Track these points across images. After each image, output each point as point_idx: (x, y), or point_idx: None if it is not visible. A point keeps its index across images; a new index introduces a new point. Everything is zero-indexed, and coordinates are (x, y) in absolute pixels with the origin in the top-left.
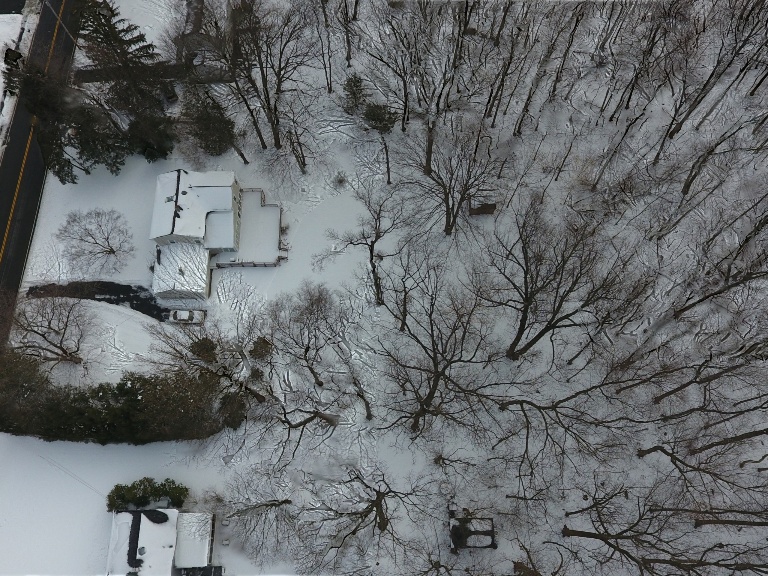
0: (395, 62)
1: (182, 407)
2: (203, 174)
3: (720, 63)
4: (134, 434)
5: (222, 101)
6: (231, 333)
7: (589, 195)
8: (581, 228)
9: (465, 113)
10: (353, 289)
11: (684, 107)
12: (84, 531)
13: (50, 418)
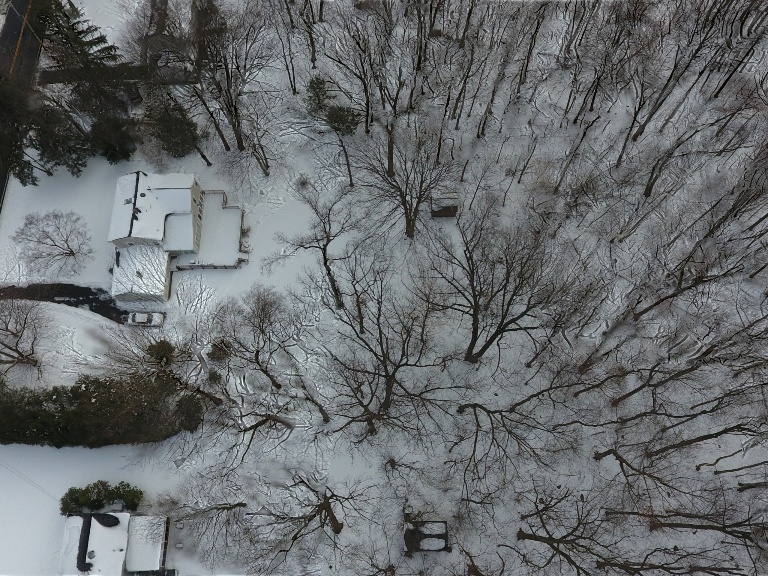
0: (354, 64)
1: (136, 410)
2: (163, 176)
3: (677, 66)
4: (87, 437)
5: (185, 102)
6: (189, 336)
7: (551, 197)
8: (543, 230)
9: (429, 115)
10: (298, 293)
11: (647, 109)
12: (38, 534)
13: (3, 421)
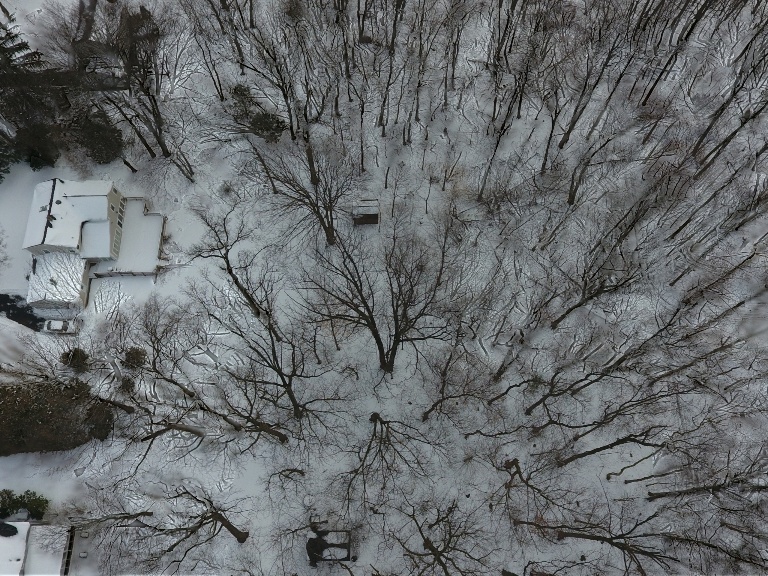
0: (270, 72)
1: (40, 419)
2: (80, 183)
3: (590, 75)
4: None
5: (111, 109)
6: None
7: (475, 205)
8: (465, 238)
9: (356, 122)
10: (183, 304)
11: None
12: None
13: None
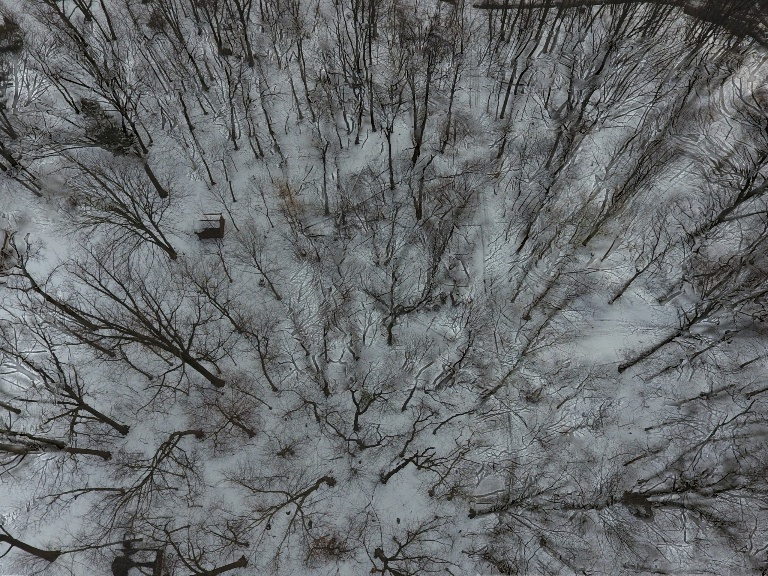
0: (100, 87)
1: None
2: None
3: (415, 91)
4: None
5: None
6: None
7: (322, 220)
8: (309, 253)
9: (209, 135)
10: None
11: None
12: None
13: None
